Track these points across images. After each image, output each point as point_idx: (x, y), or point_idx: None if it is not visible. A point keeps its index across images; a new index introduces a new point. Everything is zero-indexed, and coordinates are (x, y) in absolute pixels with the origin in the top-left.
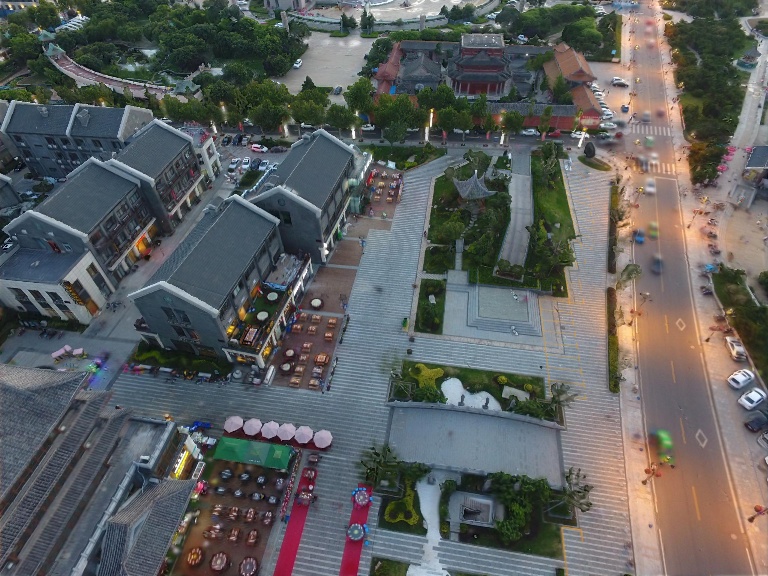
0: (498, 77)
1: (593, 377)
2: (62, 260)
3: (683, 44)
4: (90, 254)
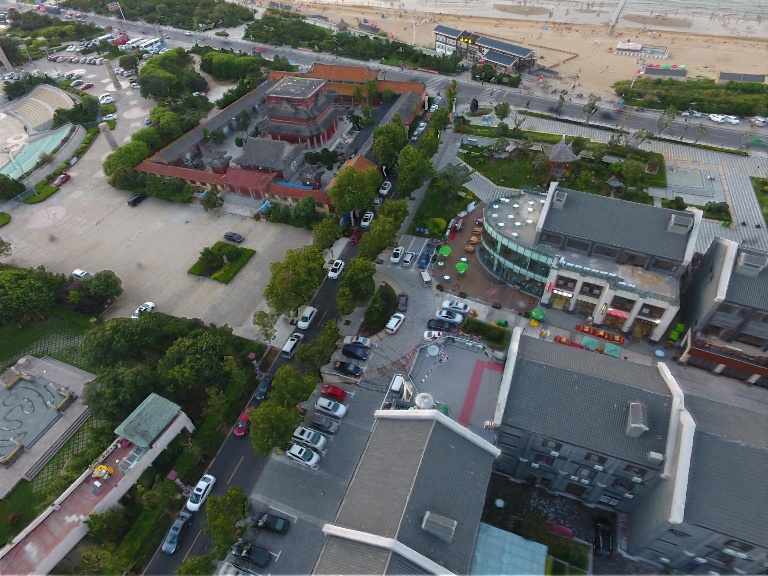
0: (337, 110)
1: (738, 160)
2: None
3: (297, 40)
4: None
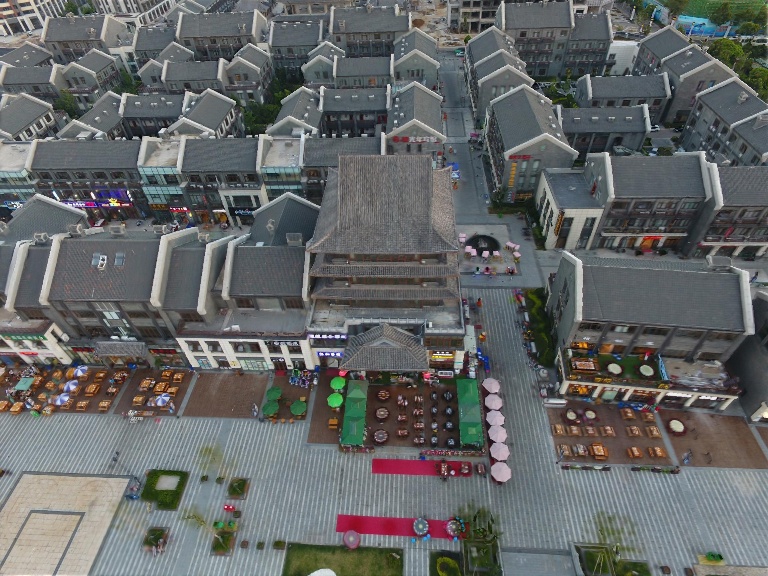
0: None
1: None
2: (585, 200)
3: None
4: (602, 211)
